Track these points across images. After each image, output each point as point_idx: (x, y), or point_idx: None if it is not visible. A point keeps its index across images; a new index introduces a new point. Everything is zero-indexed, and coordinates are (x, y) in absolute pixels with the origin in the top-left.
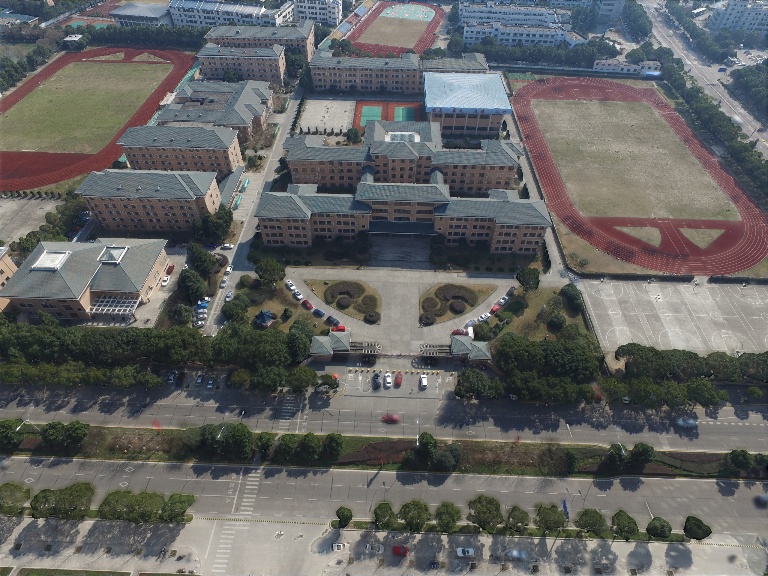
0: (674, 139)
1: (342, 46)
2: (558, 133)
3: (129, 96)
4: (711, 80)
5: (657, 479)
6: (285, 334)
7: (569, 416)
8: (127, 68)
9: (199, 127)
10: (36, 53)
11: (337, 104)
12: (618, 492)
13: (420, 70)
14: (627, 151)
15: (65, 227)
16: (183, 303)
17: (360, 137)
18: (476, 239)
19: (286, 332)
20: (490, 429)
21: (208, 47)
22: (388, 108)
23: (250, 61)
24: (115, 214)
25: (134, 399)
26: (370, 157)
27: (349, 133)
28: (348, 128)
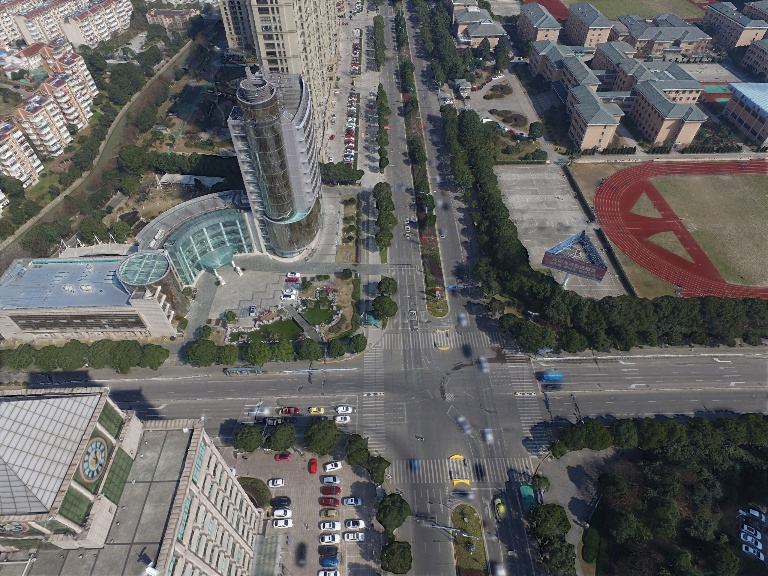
0: None
1: None
2: None
3: (650, 14)
4: None
5: (411, 170)
6: None
7: (442, 150)
8: (688, 7)
9: None
10: None
11: (726, 74)
12: (402, 158)
13: None
14: None
15: (506, 19)
16: None
17: None
18: None
19: None
20: (429, 128)
21: (721, 3)
22: None
23: (730, 23)
24: None
25: (423, 56)
26: None
27: None
28: None
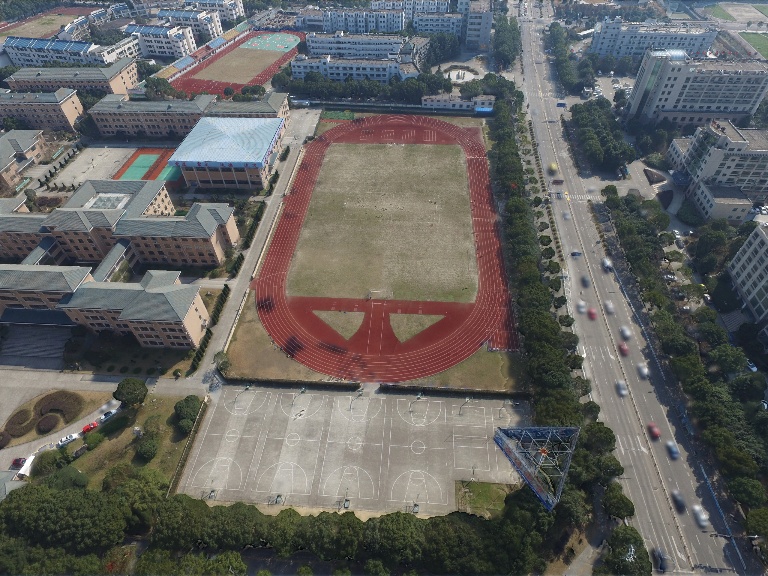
0: (461, 192)
1: (155, 85)
2: (332, 186)
3: None
4: (553, 116)
5: None
6: None
7: None
8: None
9: None
10: None
11: (114, 152)
12: None
13: (205, 114)
14: (396, 208)
15: None
16: None
17: None
18: (126, 330)
19: None
20: None
21: None
22: (165, 157)
23: (32, 107)
24: None
25: None
26: (46, 228)
27: None
28: None
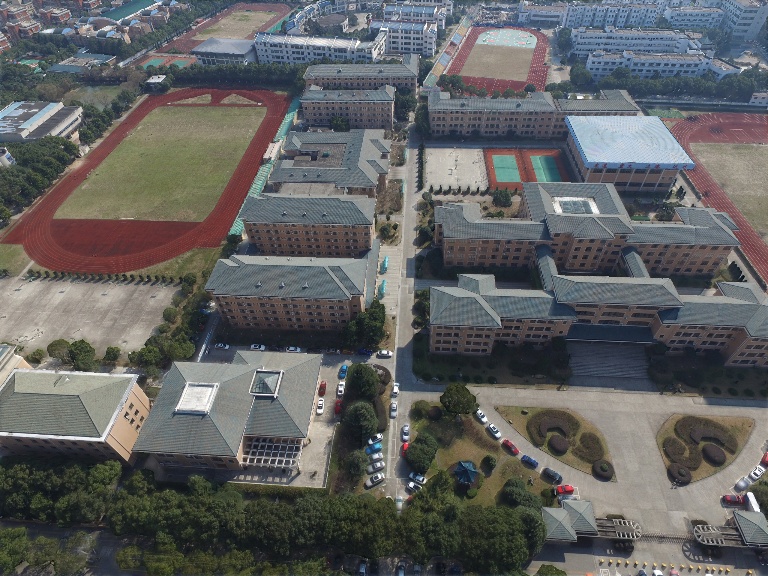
0: None
1: (453, 83)
2: (741, 188)
3: (226, 147)
4: None
5: None
6: (517, 515)
7: None
8: (217, 113)
9: (335, 198)
10: (121, 98)
11: (462, 153)
12: None
13: (558, 112)
14: None
15: (191, 331)
16: (350, 443)
17: (510, 200)
18: (705, 347)
19: (494, 492)
20: None
21: (313, 91)
22: (523, 158)
23: (359, 105)
24: (248, 313)
25: None
26: (548, 235)
27: (499, 196)
28: (484, 185)
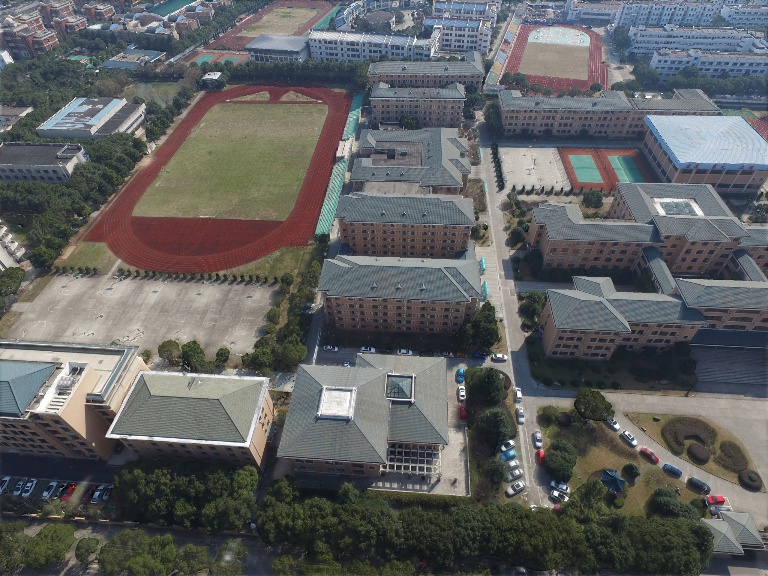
0: None
1: (517, 81)
2: None
3: (294, 145)
4: None
5: None
6: (685, 527)
7: None
8: (278, 110)
9: (435, 198)
10: (181, 95)
11: (536, 153)
12: None
13: (635, 111)
14: None
15: (302, 332)
16: (483, 449)
17: (601, 201)
18: None
19: (642, 502)
20: None
21: (383, 88)
22: (600, 157)
23: (430, 103)
24: (358, 314)
25: None
26: (657, 237)
27: (590, 196)
28: (567, 185)
